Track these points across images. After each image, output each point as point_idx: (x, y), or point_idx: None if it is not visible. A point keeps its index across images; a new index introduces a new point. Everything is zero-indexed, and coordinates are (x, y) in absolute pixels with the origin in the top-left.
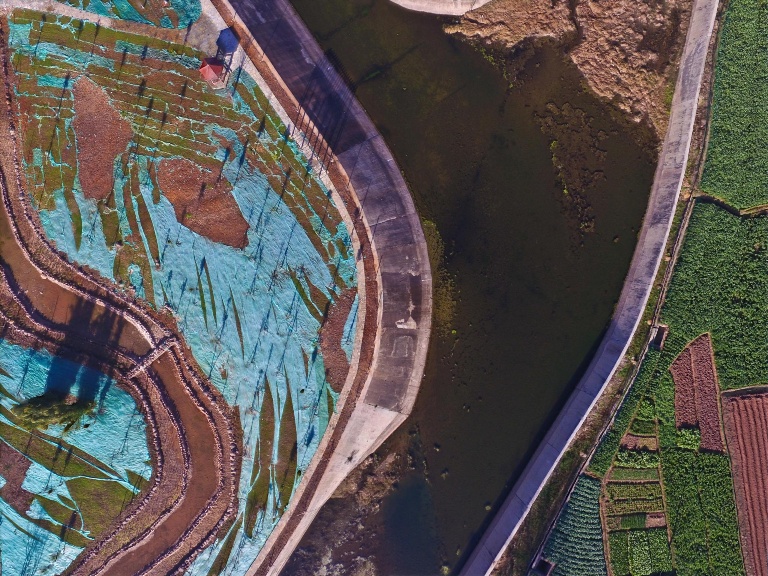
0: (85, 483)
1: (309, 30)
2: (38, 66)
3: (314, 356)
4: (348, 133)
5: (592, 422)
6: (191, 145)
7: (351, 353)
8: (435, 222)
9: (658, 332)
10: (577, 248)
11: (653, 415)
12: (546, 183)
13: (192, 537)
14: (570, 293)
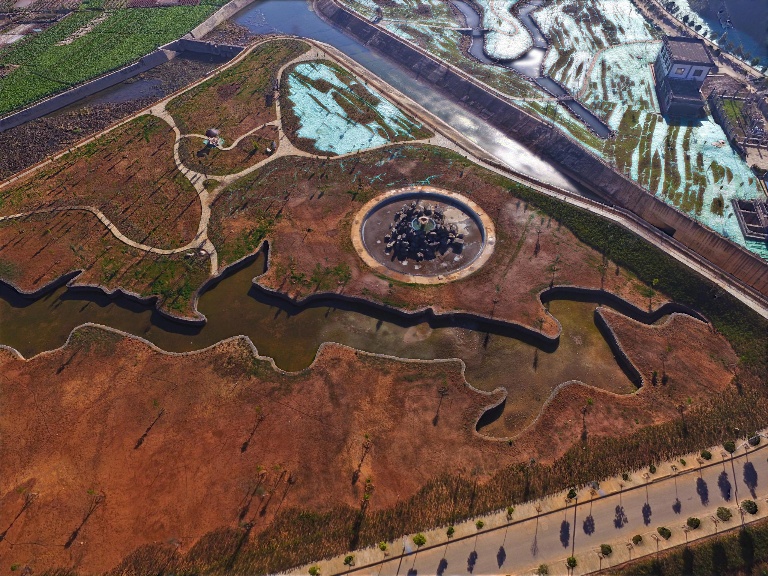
0: None
1: None
2: None
3: None
4: None
5: None
6: None
7: None
8: None
9: None
10: (263, 8)
11: None
12: None
13: None
14: None
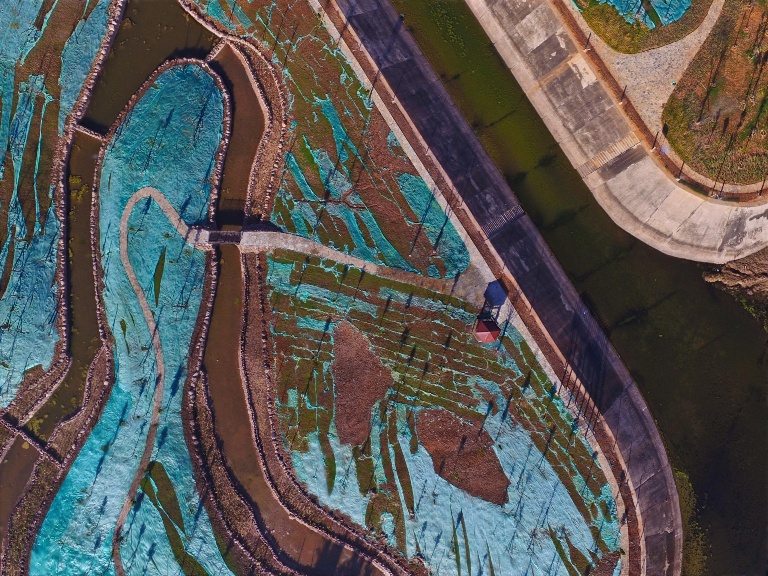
0: None
1: (564, 271)
2: (298, 307)
3: None
4: (609, 386)
5: None
6: (453, 396)
7: None
8: (688, 474)
9: None
10: None
11: None
12: None
13: None
14: None
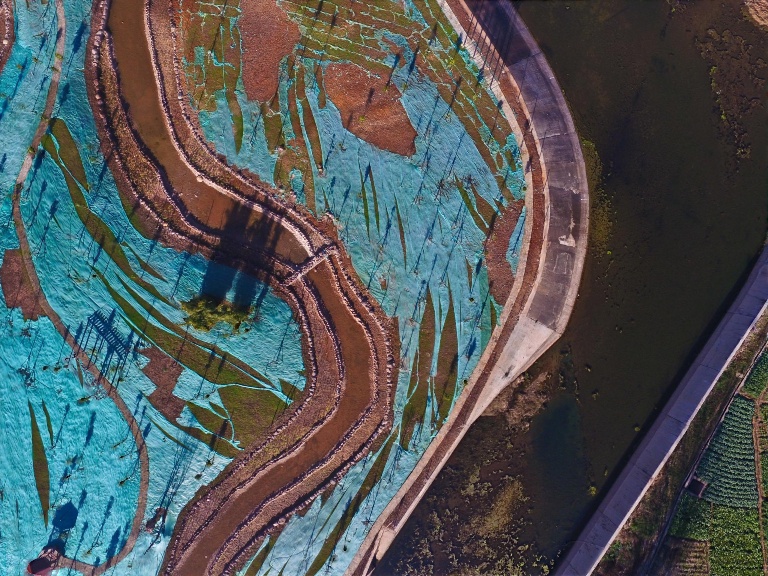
0: (238, 391)
1: None
2: None
3: (478, 268)
4: (515, 47)
5: (749, 343)
6: (360, 50)
7: (516, 266)
8: (594, 142)
9: None
10: (732, 174)
11: None
12: (704, 108)
13: (344, 450)
14: (724, 218)
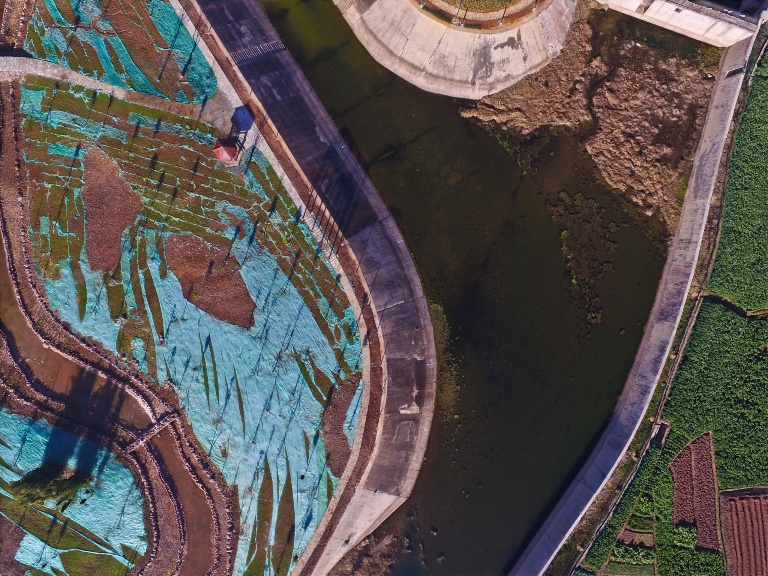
0: (79, 556)
1: (324, 107)
2: (49, 134)
3: (316, 439)
4: (359, 215)
5: (590, 516)
6: (201, 221)
7: (353, 438)
8: (442, 306)
9: (660, 428)
10: (583, 338)
11: (651, 512)
12: (555, 272)
13: None
14: (574, 383)
